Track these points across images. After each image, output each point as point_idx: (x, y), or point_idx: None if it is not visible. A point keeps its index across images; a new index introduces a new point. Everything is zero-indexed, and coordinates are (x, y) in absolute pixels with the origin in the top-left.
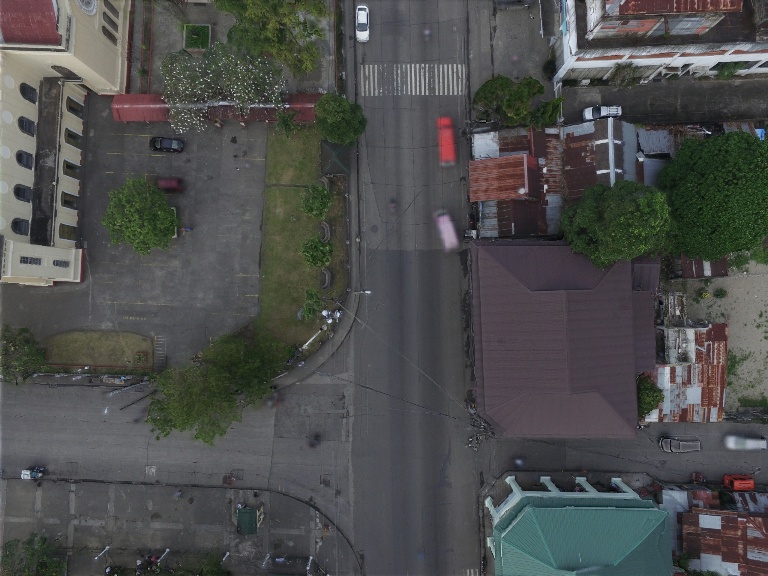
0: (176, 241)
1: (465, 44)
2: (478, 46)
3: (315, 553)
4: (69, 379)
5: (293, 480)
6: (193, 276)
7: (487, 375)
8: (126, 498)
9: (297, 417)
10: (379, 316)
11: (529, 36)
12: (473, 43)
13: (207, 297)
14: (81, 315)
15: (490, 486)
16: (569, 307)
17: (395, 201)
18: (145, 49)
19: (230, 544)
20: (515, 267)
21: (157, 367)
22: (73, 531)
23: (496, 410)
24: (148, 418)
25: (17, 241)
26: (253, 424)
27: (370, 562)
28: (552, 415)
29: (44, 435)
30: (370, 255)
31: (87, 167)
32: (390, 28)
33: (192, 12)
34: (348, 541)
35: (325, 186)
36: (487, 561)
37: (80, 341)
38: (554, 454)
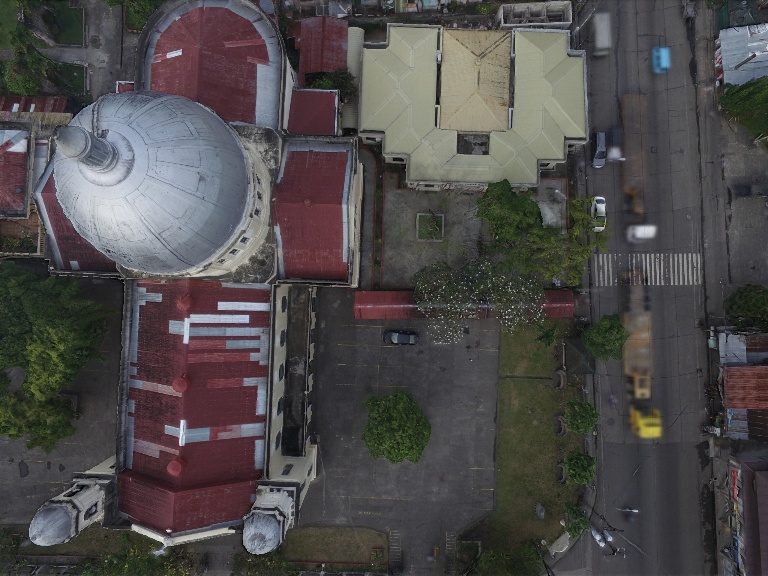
0: None
1: (699, 232)
2: (713, 235)
3: None
4: (305, 575)
5: None
6: (428, 470)
7: None
8: None
9: None
10: (617, 511)
11: (765, 225)
12: (708, 232)
13: (442, 491)
14: (315, 510)
15: None
16: None
17: (632, 394)
18: (377, 239)
19: None
20: None
21: (393, 563)
22: None
23: None
24: None
25: (278, 459)
26: None
27: None
28: None
29: None
30: (607, 448)
31: (319, 359)
32: (624, 216)
33: (423, 200)
34: None
35: (561, 379)
36: None
37: (314, 537)
38: None
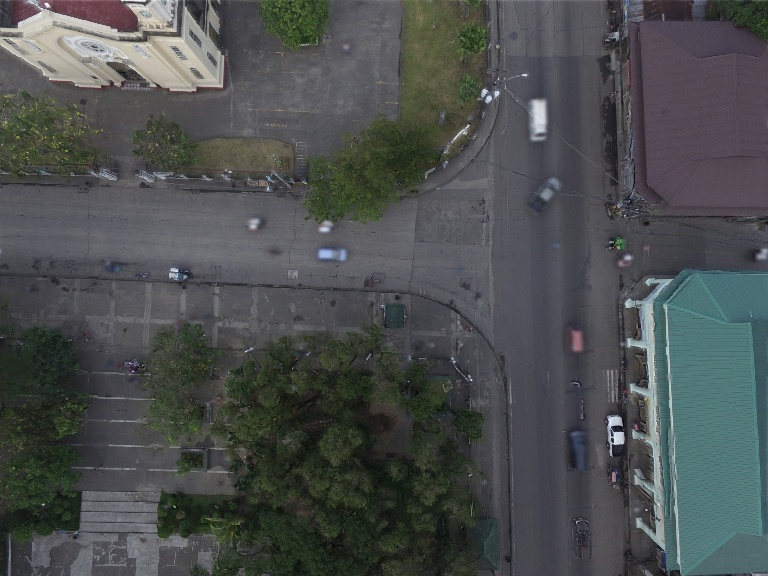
0: (316, 49)
1: None
2: None
3: (456, 354)
4: (212, 184)
5: (434, 283)
6: (333, 84)
7: (649, 148)
8: (269, 301)
9: (437, 222)
10: (519, 122)
11: None
12: None
13: (347, 104)
14: (223, 122)
15: (629, 289)
16: (738, 70)
17: (534, 8)
18: None
19: (372, 346)
20: (679, 39)
21: (298, 173)
22: (217, 333)
23: (659, 181)
24: (306, 200)
25: None
26: (394, 229)
27: (510, 363)
28: (716, 184)
29: (188, 239)
30: (509, 62)
31: None
32: None
33: None
34: (488, 343)
35: None
36: (628, 361)
37: (222, 147)
38: (693, 258)
